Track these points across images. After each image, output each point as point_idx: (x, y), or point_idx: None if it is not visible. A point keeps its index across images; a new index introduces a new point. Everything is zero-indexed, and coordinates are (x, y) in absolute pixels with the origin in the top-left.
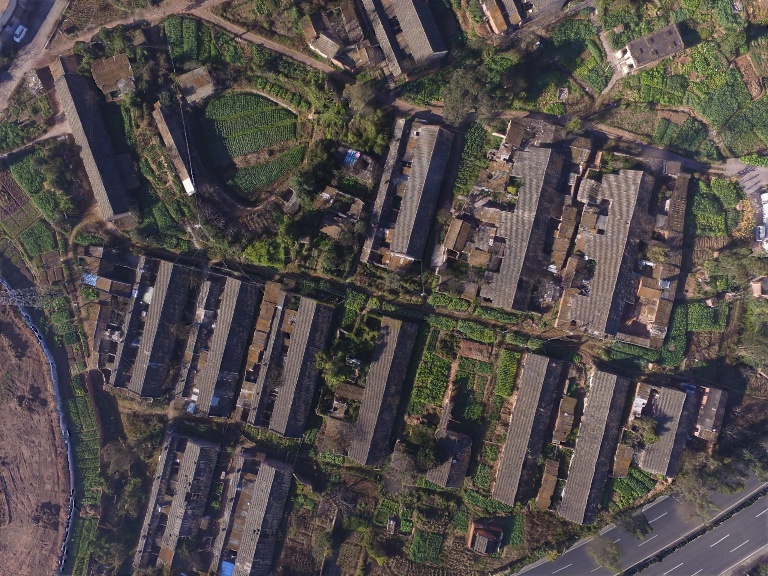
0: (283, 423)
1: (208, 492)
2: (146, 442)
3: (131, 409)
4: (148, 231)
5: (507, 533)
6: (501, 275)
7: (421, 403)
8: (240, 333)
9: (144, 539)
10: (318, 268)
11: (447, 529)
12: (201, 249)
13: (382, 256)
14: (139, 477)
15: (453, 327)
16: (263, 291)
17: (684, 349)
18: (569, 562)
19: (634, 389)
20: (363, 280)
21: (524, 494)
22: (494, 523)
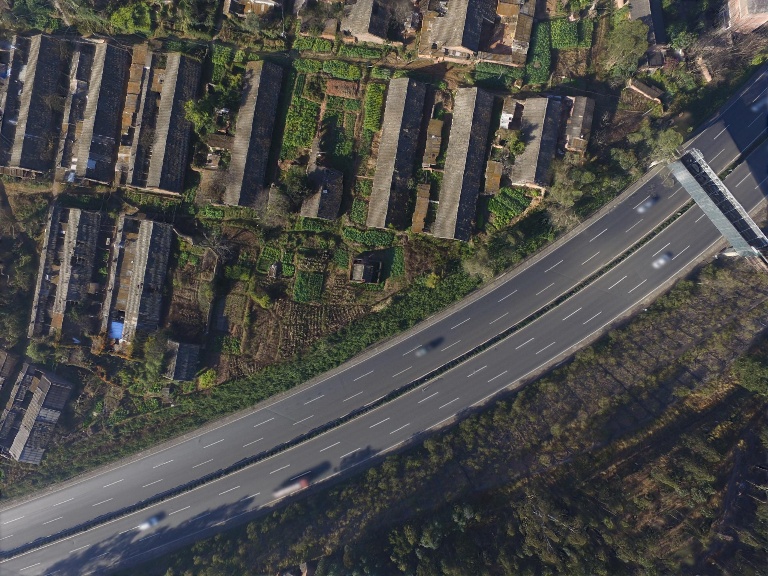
0: (158, 177)
1: (94, 258)
2: (33, 219)
3: (17, 191)
4: (19, 13)
5: (387, 266)
6: (358, 4)
7: (293, 147)
8: (112, 97)
9: (35, 309)
10: (183, 27)
11: (328, 268)
12: (71, 25)
13: (244, 7)
14: (29, 254)
15: (319, 68)
16: (131, 55)
17: (549, 64)
18: (467, 317)
19: (501, 108)
20: (228, 34)
21: (396, 217)
22: (374, 258)
